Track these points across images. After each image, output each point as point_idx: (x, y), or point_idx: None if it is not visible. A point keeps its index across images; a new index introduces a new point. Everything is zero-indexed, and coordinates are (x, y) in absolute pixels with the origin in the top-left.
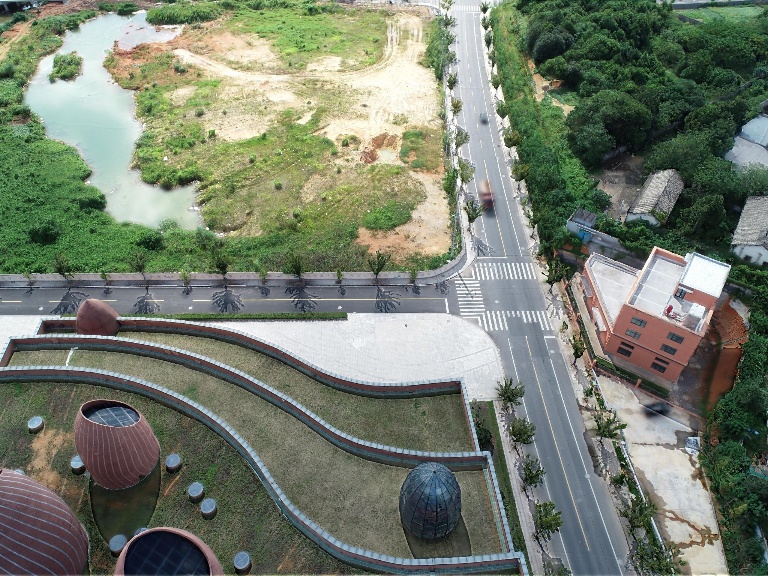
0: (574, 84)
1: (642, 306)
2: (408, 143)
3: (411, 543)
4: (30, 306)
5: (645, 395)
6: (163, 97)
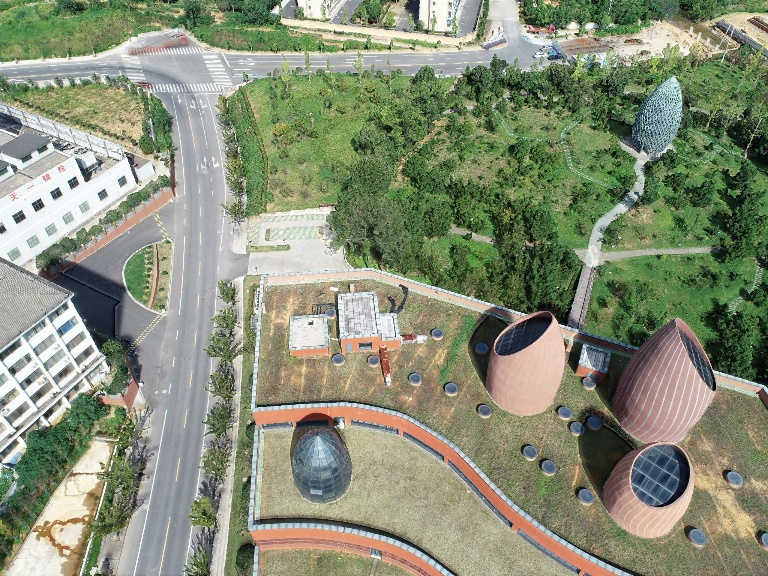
0: None
1: None
2: None
3: None
4: None
5: None
6: None
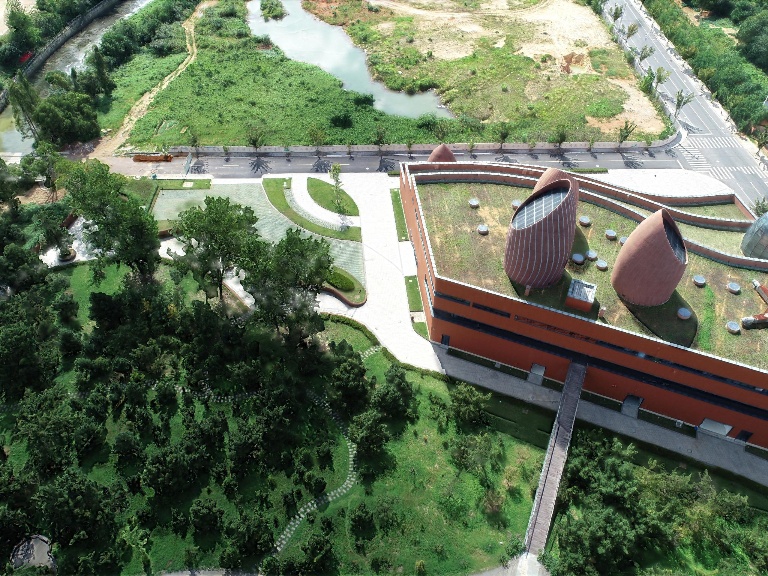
0: (723, 13)
1: None
2: (597, 59)
3: None
4: (358, 167)
5: None
6: (371, 29)
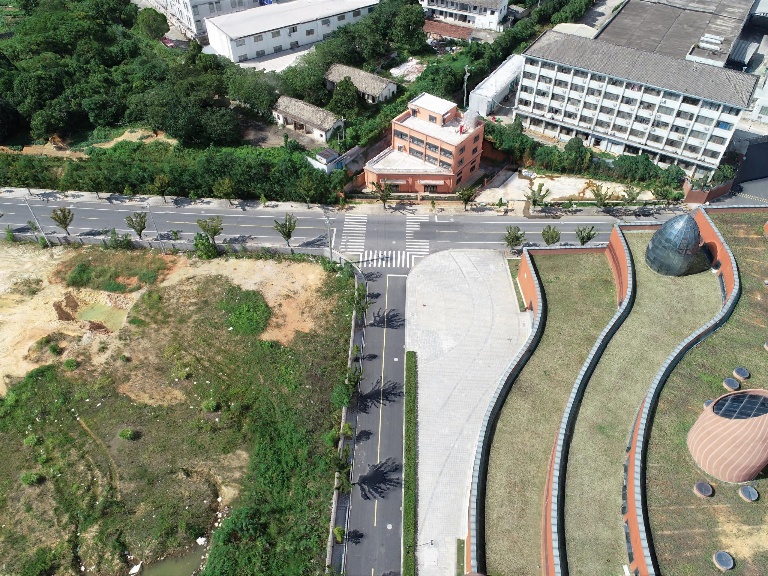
0: (77, 126)
1: (453, 142)
2: (100, 280)
3: (694, 273)
4: None
5: (491, 184)
6: None
